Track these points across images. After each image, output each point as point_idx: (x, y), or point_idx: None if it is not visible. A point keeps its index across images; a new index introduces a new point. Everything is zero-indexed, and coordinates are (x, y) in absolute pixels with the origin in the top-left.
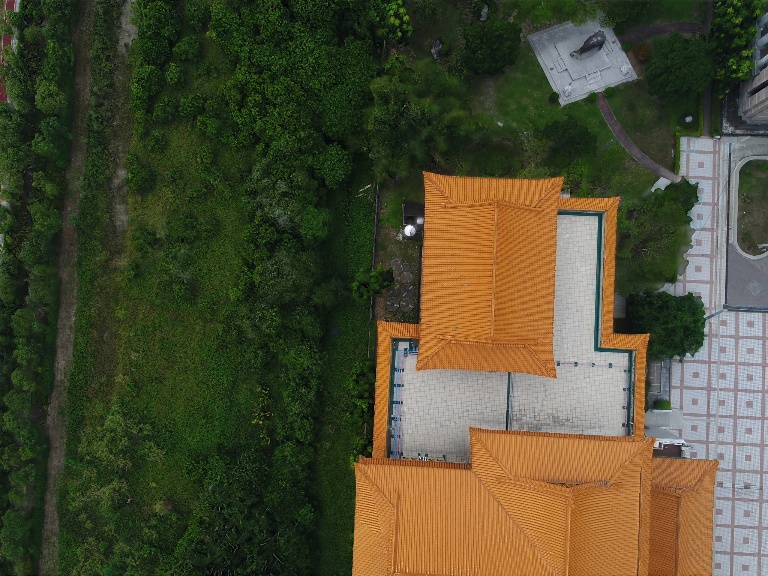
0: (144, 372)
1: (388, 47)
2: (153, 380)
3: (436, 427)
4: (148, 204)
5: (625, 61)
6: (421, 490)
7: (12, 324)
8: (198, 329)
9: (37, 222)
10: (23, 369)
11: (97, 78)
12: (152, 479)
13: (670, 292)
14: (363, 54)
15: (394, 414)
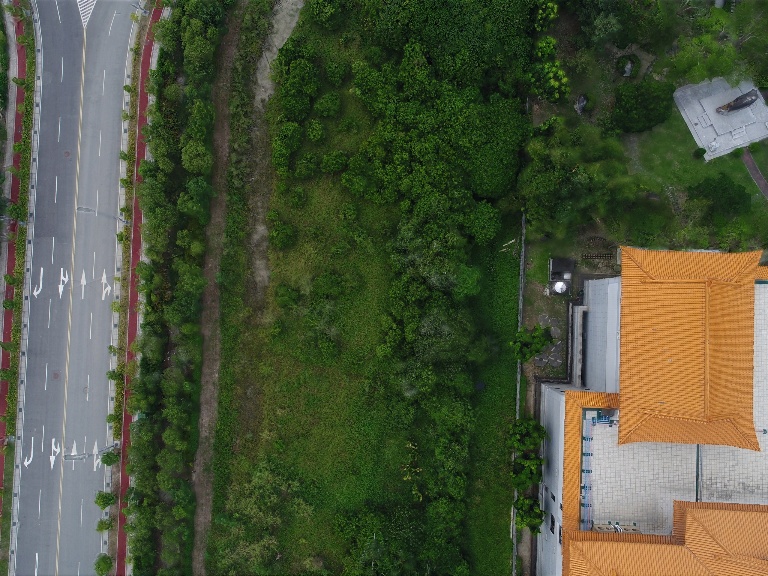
0: (290, 428)
1: (531, 103)
2: (300, 436)
3: (626, 495)
4: (290, 260)
5: None
6: (637, 567)
7: (162, 383)
8: (343, 385)
9: (186, 282)
10: (174, 428)
11: (236, 134)
12: (300, 535)
13: None
14: (512, 112)
15: (584, 483)
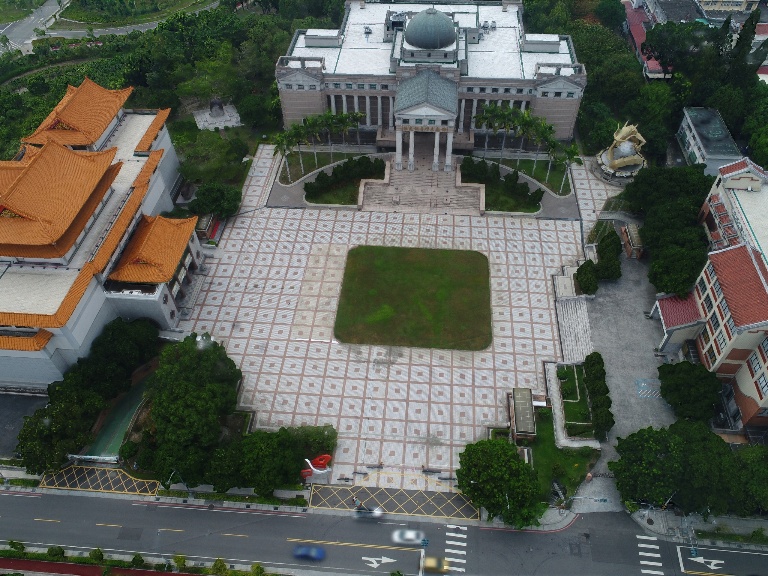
0: None
1: None
2: None
3: None
4: None
5: None
6: None
7: None
8: None
9: None
10: None
11: None
12: None
13: None
14: None
15: None
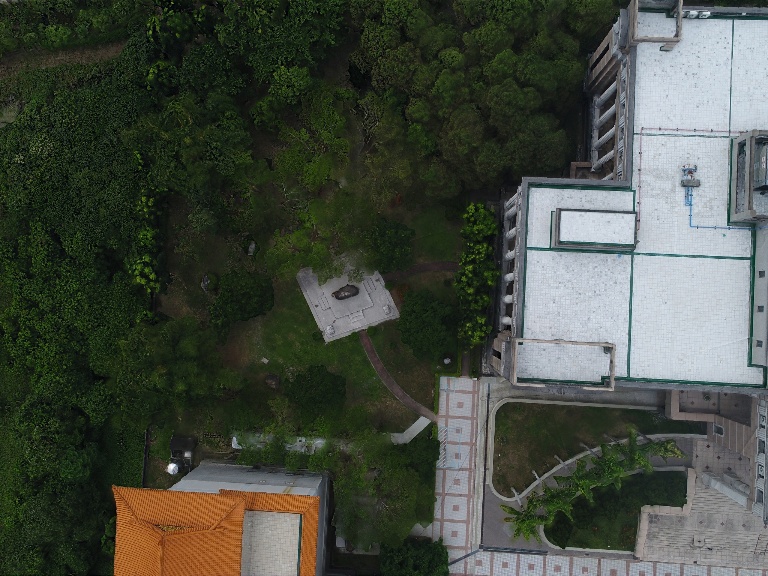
0: None
1: None
2: None
3: None
4: None
5: (388, 299)
6: None
7: None
8: None
9: None
10: None
11: None
12: None
13: (428, 531)
14: (125, 296)
15: None
